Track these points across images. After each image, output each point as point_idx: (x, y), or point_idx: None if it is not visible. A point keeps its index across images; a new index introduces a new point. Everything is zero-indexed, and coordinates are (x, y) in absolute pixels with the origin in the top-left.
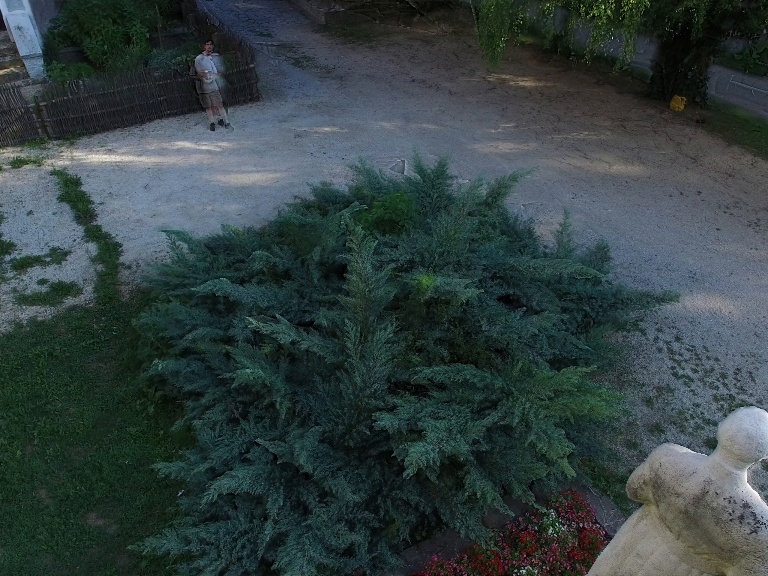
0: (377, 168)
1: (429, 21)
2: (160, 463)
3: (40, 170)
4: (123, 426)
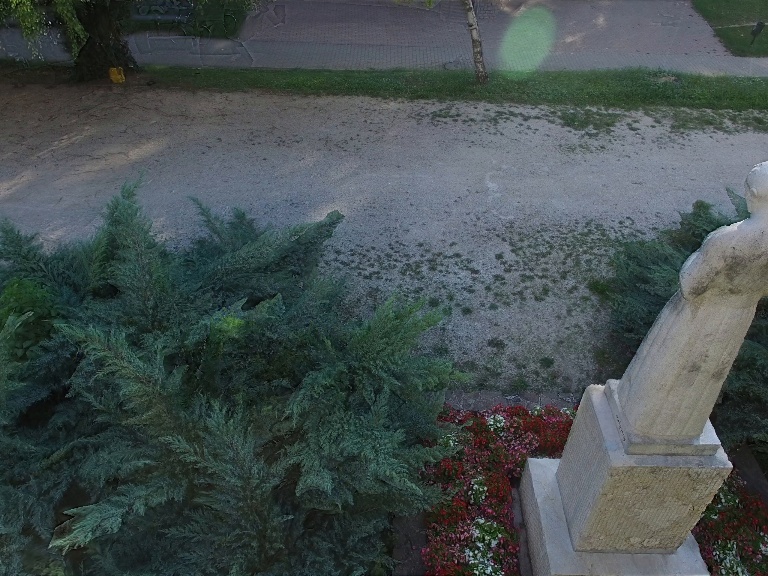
0: None
1: None
2: None
3: None
4: None
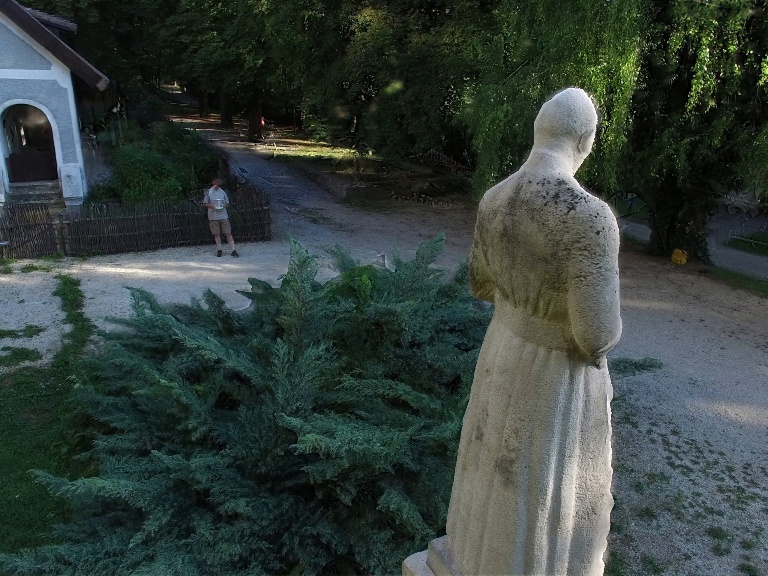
0: (354, 256)
1: (440, 193)
2: (41, 471)
3: (47, 274)
4: (30, 467)
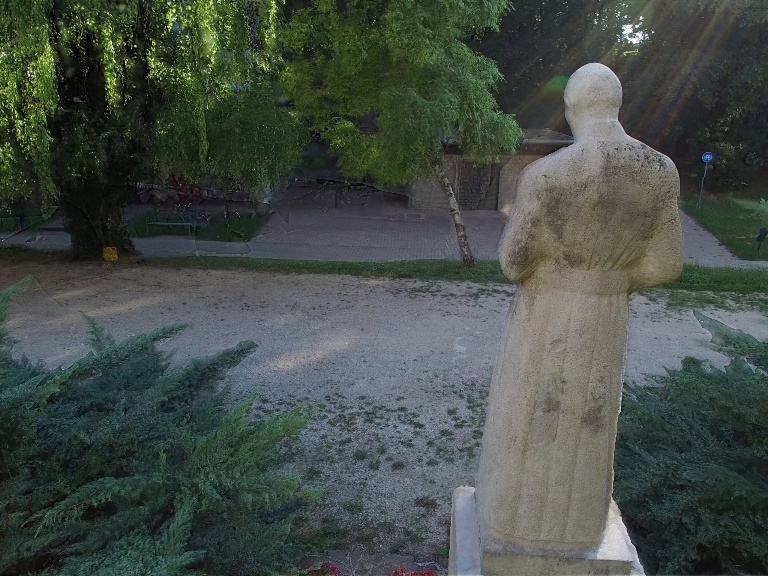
0: None
1: None
2: None
3: None
4: None
